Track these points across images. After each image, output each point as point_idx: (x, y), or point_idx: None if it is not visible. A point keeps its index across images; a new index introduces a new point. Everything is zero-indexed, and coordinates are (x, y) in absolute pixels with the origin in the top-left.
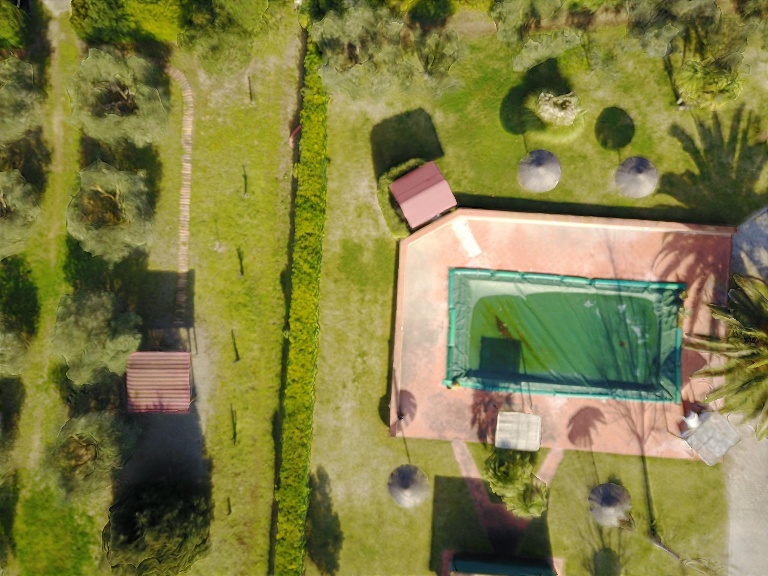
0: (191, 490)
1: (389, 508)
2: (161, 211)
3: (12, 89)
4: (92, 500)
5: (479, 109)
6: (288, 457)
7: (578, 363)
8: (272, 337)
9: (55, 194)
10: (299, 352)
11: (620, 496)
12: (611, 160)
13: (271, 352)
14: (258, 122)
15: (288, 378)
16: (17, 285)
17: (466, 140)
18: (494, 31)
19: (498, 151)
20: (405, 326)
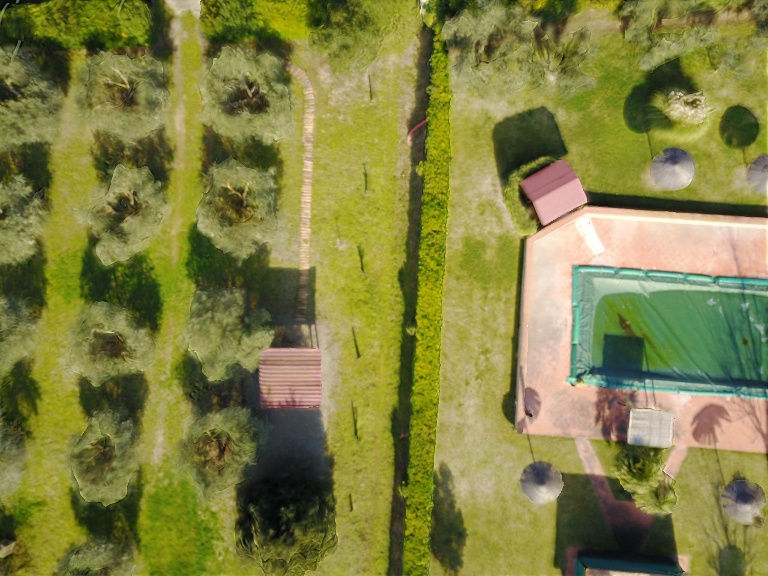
0: (318, 486)
1: (513, 505)
2: (282, 208)
3: (149, 87)
4: (215, 496)
5: (602, 108)
6: (416, 454)
7: (701, 361)
8: (390, 334)
9: (177, 191)
10: (426, 349)
11: (755, 493)
12: (736, 159)
13: (389, 349)
14: (378, 120)
15: (416, 375)
16: (140, 282)
17: (590, 138)
18: (615, 30)
19: (622, 149)
20: (528, 323)
